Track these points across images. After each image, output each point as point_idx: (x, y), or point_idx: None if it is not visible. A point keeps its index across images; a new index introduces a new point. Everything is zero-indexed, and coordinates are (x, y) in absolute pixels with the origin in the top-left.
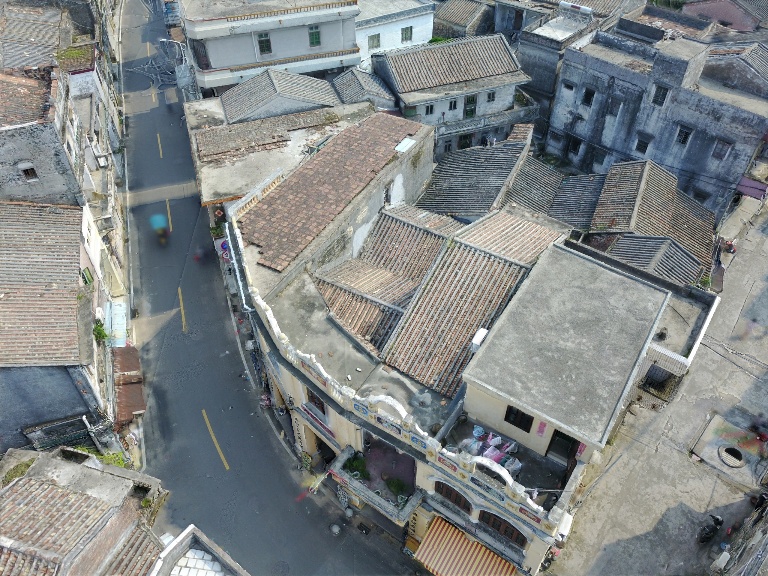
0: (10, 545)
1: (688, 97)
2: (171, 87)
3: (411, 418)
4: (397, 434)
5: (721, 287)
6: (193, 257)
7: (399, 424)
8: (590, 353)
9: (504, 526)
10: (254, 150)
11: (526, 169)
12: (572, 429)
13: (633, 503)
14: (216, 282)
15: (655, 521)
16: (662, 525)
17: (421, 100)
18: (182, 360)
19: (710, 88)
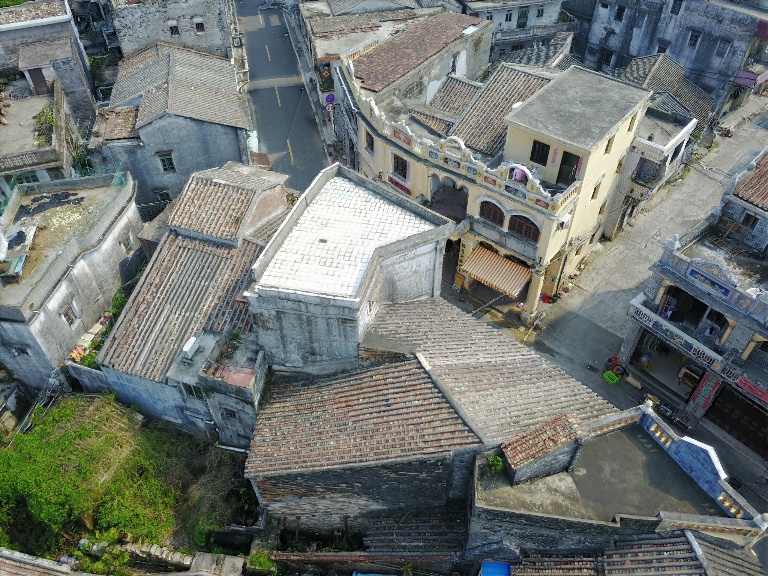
0: (225, 183)
1: (698, 5)
2: (275, 14)
3: (468, 150)
4: (457, 169)
5: (710, 144)
6: (297, 122)
7: (459, 158)
8: (591, 114)
9: (525, 227)
10: (354, 31)
11: (564, 63)
12: (572, 143)
13: (623, 273)
14: (316, 138)
15: (638, 283)
16: (643, 285)
17: (484, 7)
18: (292, 180)
19: (719, 2)
